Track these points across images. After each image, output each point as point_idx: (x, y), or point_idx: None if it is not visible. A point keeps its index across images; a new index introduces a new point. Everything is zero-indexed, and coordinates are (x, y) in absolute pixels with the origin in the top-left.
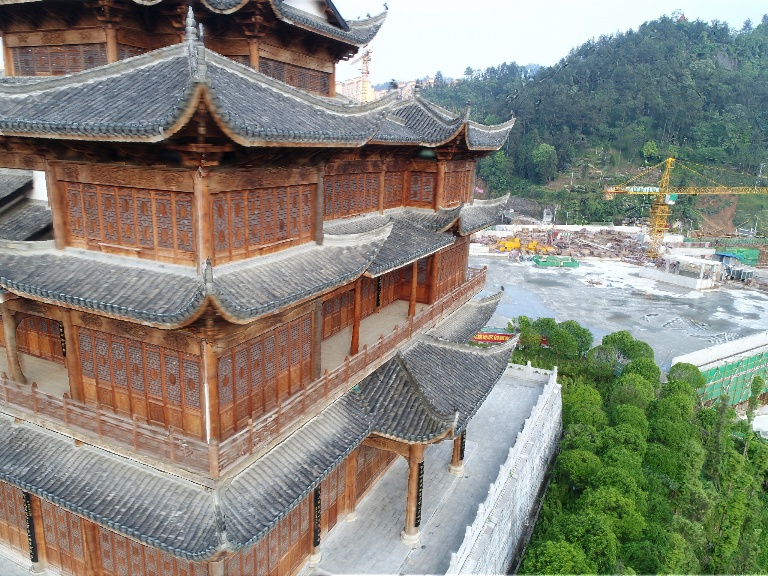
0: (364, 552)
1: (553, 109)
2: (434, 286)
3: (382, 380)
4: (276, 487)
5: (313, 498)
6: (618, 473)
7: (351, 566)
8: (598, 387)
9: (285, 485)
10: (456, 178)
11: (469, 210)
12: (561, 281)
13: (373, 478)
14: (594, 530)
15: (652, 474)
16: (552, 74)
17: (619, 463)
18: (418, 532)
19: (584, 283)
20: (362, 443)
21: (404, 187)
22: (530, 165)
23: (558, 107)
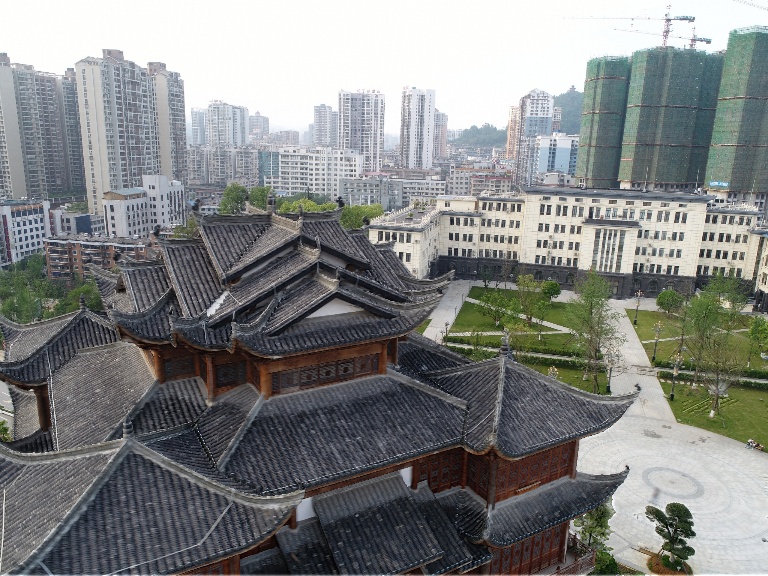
0: None
1: None
2: None
3: None
4: None
5: None
6: None
7: None
8: None
9: None
10: None
11: None
12: None
13: None
14: None
15: None
16: None
17: None
18: None
19: None
20: None
21: None
22: None
23: None
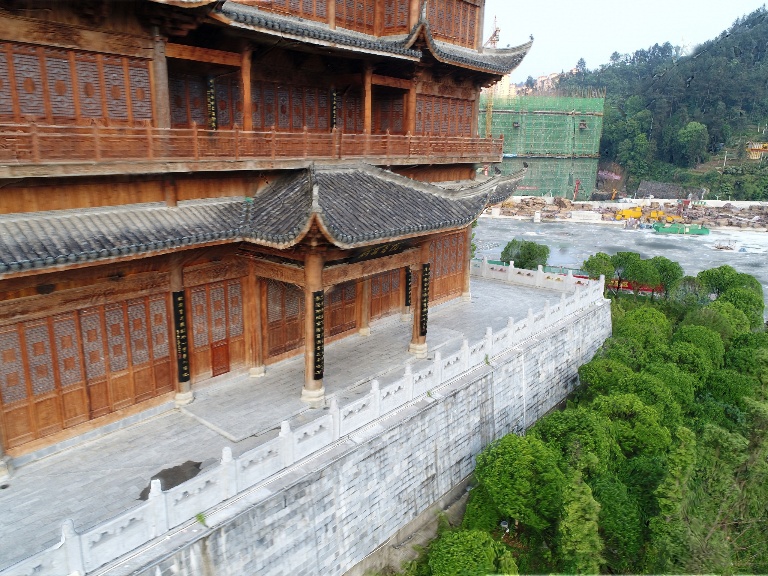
0: (247, 402)
1: (707, 84)
2: (410, 132)
3: (283, 193)
4: (45, 242)
5: (173, 318)
6: (646, 380)
7: (221, 411)
8: (678, 324)
9: (61, 244)
10: (449, 6)
11: (473, 55)
12: (681, 245)
13: (303, 341)
14: (580, 428)
15: (713, 402)
16: (709, 48)
17: (658, 376)
18: (321, 389)
19: (710, 248)
20: (261, 275)
21: (376, 11)
22: (676, 147)
23: (713, 82)
